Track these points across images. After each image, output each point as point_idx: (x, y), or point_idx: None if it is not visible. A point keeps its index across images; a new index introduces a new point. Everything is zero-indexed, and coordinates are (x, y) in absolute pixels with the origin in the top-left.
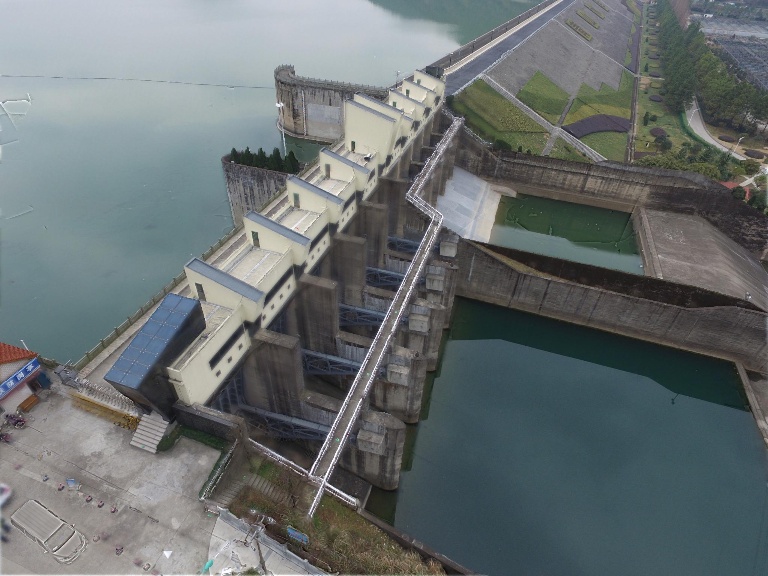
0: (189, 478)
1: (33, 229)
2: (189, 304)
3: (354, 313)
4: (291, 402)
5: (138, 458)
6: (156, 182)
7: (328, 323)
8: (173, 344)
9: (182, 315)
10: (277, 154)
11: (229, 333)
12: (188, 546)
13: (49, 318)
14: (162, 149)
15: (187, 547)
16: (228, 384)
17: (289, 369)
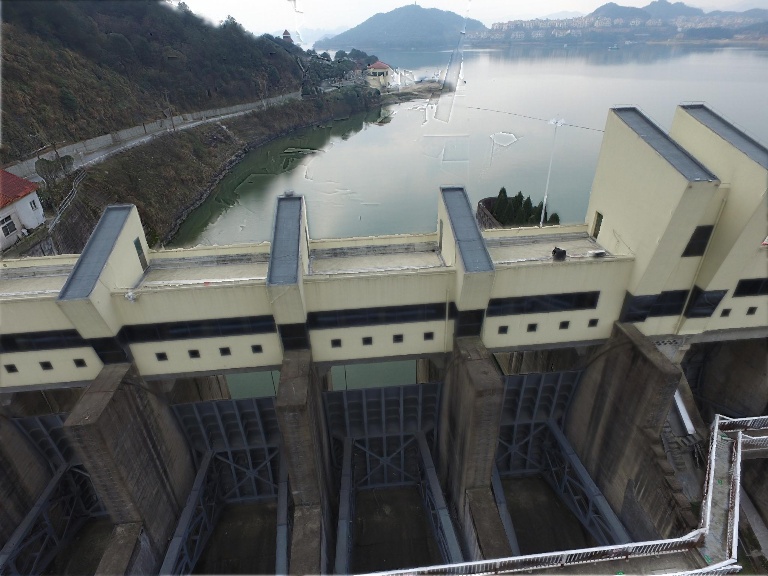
0: None
1: None
2: None
3: None
4: None
5: None
6: None
7: None
8: None
9: None
10: (539, 213)
11: None
12: None
13: None
14: (549, 198)
15: None
16: None
17: None
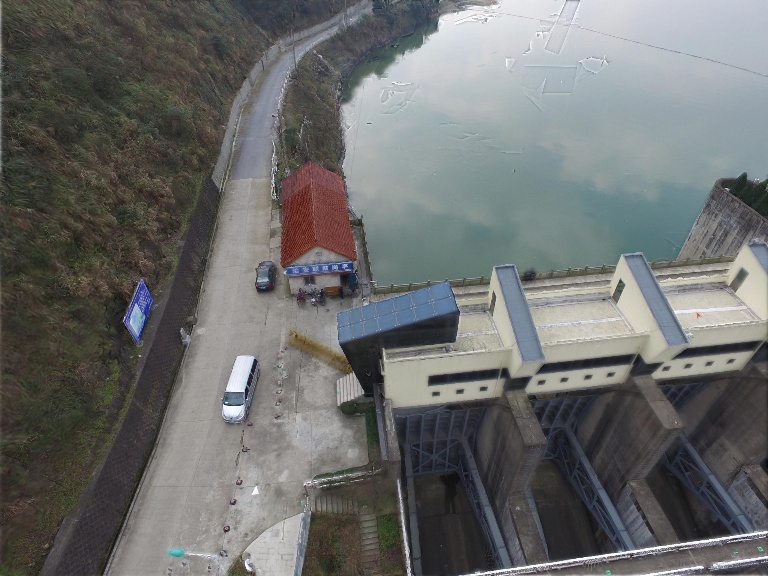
0: (330, 454)
1: (506, 168)
2: (449, 307)
3: (704, 478)
4: (501, 490)
5: (328, 397)
6: (641, 175)
7: (631, 458)
8: (404, 332)
9: (432, 312)
10: None
11: (475, 366)
12: (267, 505)
13: (447, 241)
14: (682, 145)
15: (266, 504)
16: (458, 410)
17: (514, 460)
